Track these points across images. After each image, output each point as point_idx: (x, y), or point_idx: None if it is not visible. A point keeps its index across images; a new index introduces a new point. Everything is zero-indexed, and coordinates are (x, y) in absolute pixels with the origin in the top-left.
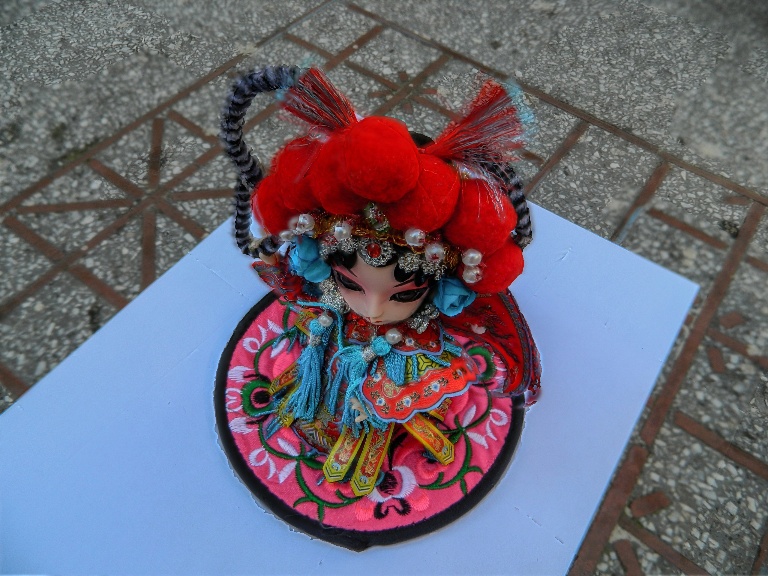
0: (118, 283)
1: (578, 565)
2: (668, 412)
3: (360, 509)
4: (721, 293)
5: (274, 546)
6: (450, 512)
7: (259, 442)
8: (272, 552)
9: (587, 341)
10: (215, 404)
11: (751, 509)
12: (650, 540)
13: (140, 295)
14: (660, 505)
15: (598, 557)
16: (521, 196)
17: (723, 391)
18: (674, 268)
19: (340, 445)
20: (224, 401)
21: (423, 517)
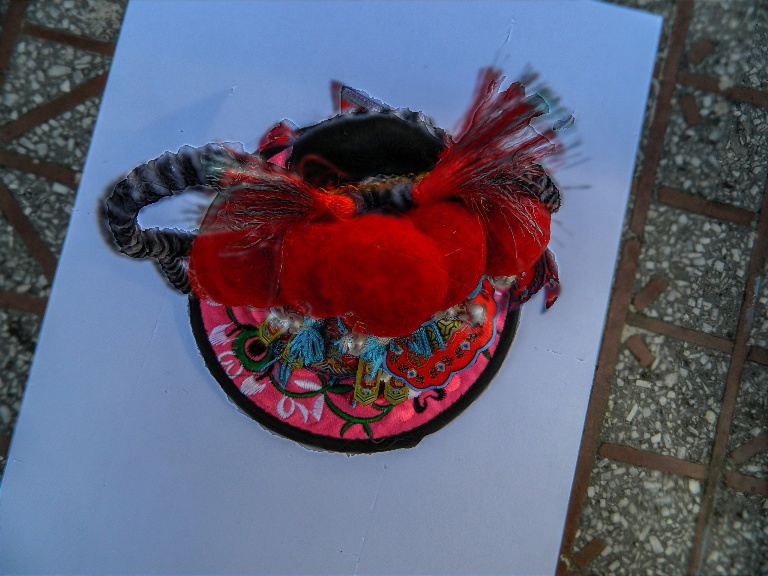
0: (17, 283)
1: (600, 374)
2: (652, 192)
3: (401, 412)
4: (686, 18)
5: (339, 472)
6: (482, 381)
7: (278, 393)
8: (340, 477)
9: (559, 142)
10: (215, 378)
11: (735, 260)
12: (655, 326)
13: (53, 287)
14: (659, 291)
15: (615, 360)
16: (552, 190)
17: (700, 145)
18: (632, 2)
19: (362, 373)
20: (222, 370)
21: (459, 395)
